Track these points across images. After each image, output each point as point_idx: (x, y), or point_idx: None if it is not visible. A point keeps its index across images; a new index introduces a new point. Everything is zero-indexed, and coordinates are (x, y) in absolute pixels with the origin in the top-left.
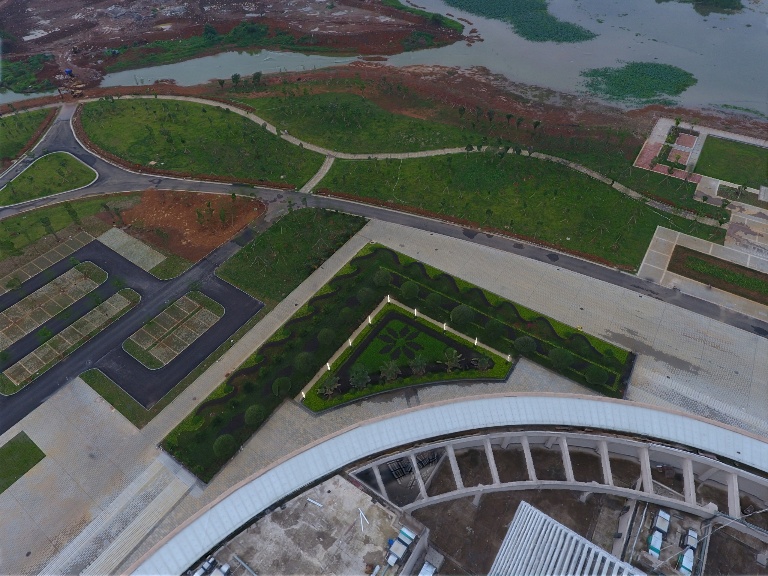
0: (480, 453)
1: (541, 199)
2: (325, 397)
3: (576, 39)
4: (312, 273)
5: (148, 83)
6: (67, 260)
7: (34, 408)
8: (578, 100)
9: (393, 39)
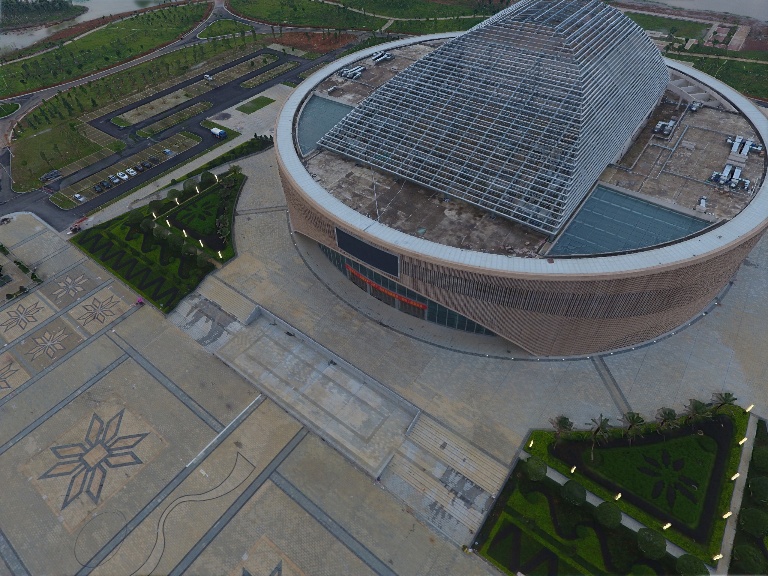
0: None
1: None
2: None
3: None
4: None
5: None
6: None
7: (263, 91)
8: None
9: None
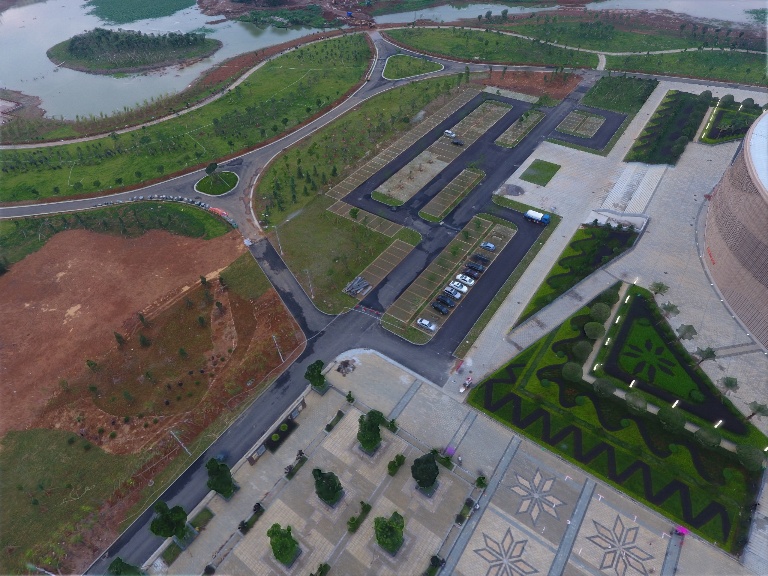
0: None
1: None
2: (714, 137)
3: None
4: (645, 102)
5: (413, 21)
6: (475, 100)
7: None
8: (754, 26)
9: None
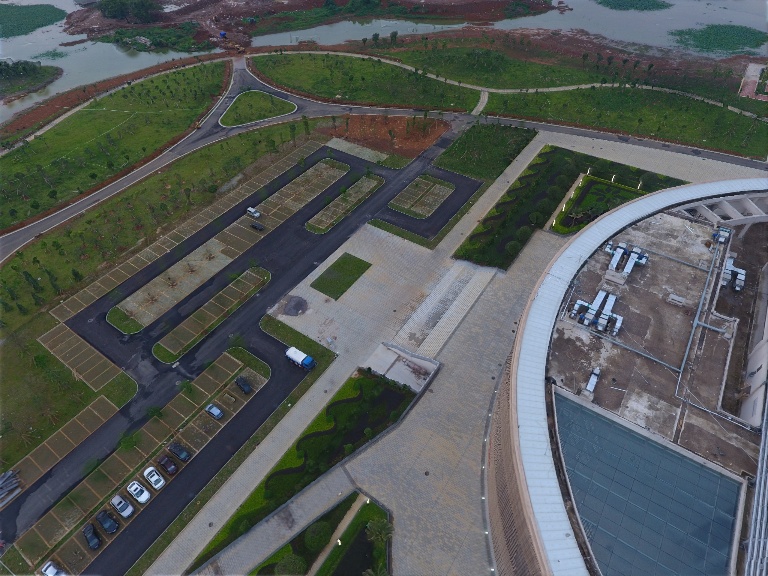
0: (730, 218)
1: (673, 116)
2: (568, 225)
3: (655, 8)
4: (510, 163)
5: (294, 43)
6: (310, 158)
7: (345, 240)
8: (674, 52)
9: (494, 8)
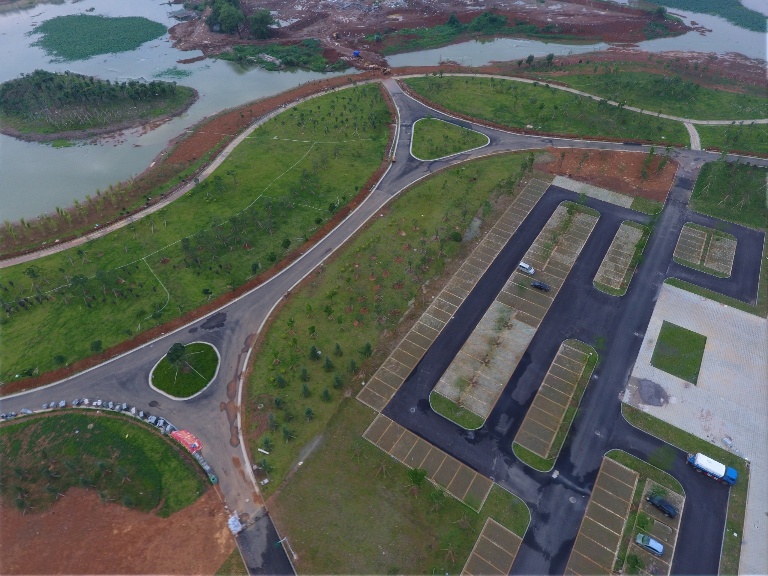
0: None
1: None
2: None
3: None
4: None
5: (435, 64)
6: (545, 200)
7: (654, 305)
8: None
9: (632, 29)
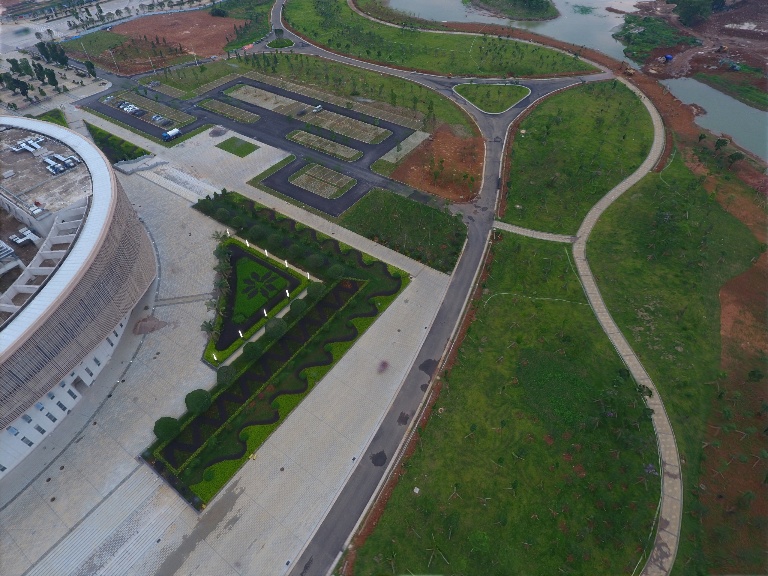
0: None
1: (512, 470)
2: None
3: None
4: (369, 239)
5: None
6: (395, 126)
7: (274, 147)
8: None
9: None
